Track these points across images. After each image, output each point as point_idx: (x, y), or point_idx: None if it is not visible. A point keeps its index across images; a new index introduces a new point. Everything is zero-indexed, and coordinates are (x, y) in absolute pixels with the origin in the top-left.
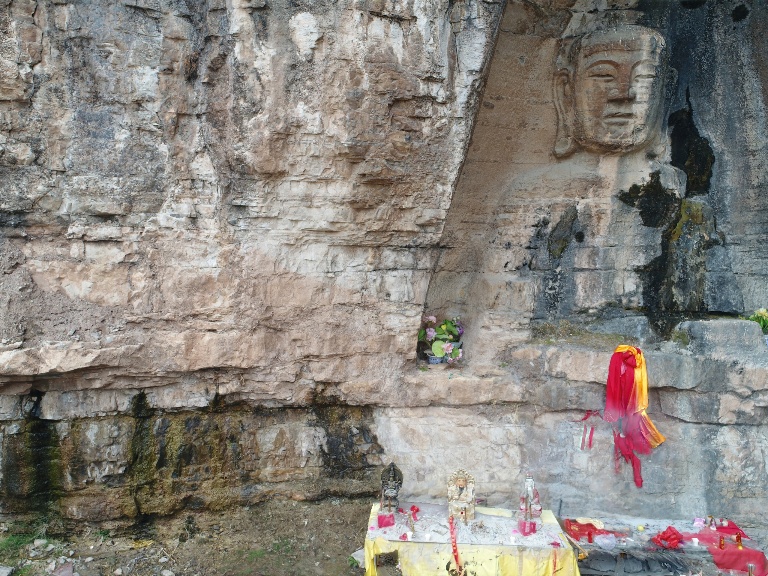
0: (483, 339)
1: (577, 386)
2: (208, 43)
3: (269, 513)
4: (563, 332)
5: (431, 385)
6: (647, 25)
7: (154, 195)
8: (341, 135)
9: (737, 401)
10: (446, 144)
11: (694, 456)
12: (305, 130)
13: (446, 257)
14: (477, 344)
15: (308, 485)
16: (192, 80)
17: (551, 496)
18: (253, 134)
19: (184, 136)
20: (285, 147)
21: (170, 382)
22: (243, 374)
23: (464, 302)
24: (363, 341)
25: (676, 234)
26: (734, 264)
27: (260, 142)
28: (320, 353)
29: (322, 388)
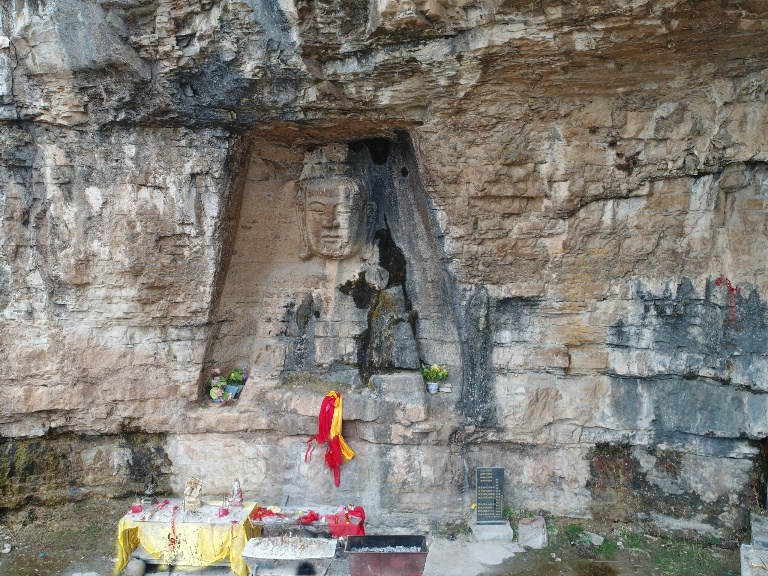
0: (247, 386)
1: (303, 419)
2: (35, 201)
3: (87, 507)
4: (304, 380)
5: (205, 418)
6: (351, 175)
7: (2, 298)
8: (124, 260)
9: (402, 429)
10: (202, 261)
11: (373, 466)
12: (99, 258)
13: (228, 327)
14: (244, 389)
15: (117, 487)
16: (26, 224)
17: (283, 493)
18: (63, 261)
19: (22, 259)
20: (88, 267)
21: (16, 420)
22: (68, 413)
23: (249, 356)
24: (155, 390)
25: (375, 315)
26: (424, 332)
27: (68, 266)
28: (123, 398)
29: (128, 421)
